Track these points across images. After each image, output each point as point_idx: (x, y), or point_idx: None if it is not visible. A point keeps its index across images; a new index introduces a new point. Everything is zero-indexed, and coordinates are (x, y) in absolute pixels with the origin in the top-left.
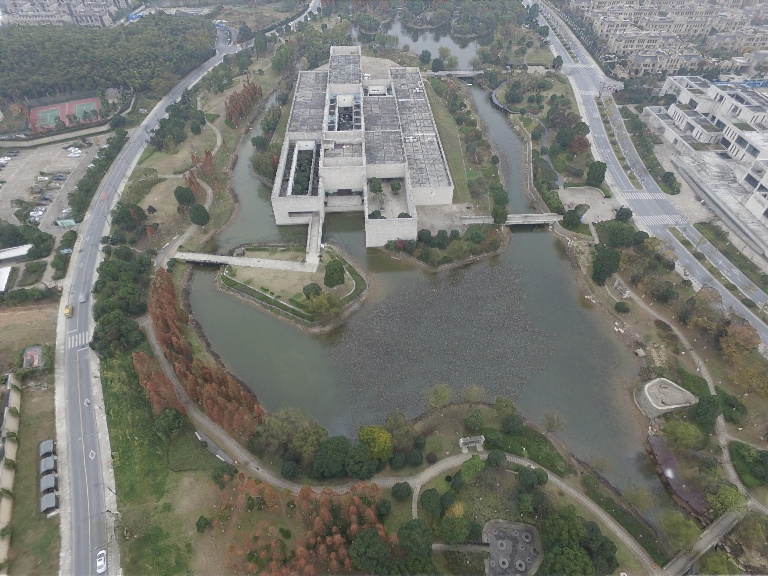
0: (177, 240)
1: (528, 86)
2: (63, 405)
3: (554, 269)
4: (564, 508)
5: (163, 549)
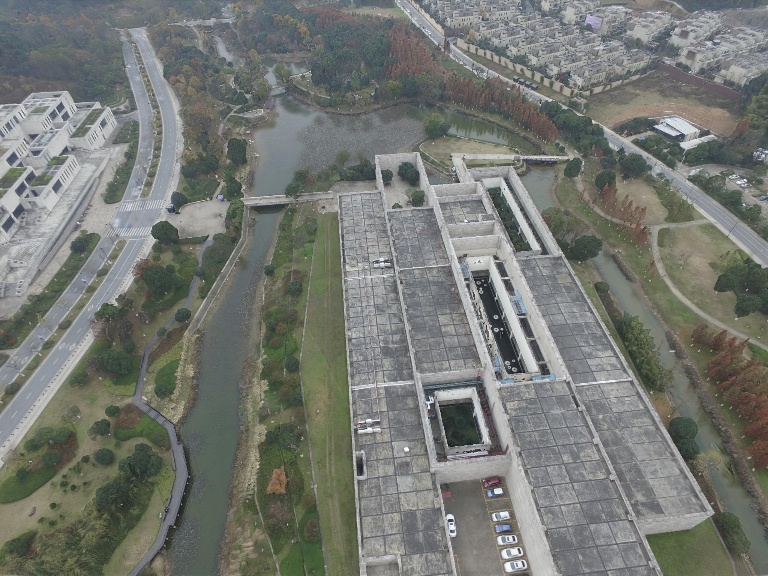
0: None
1: (65, 531)
2: (547, 99)
3: (269, 172)
4: None
5: (465, 75)
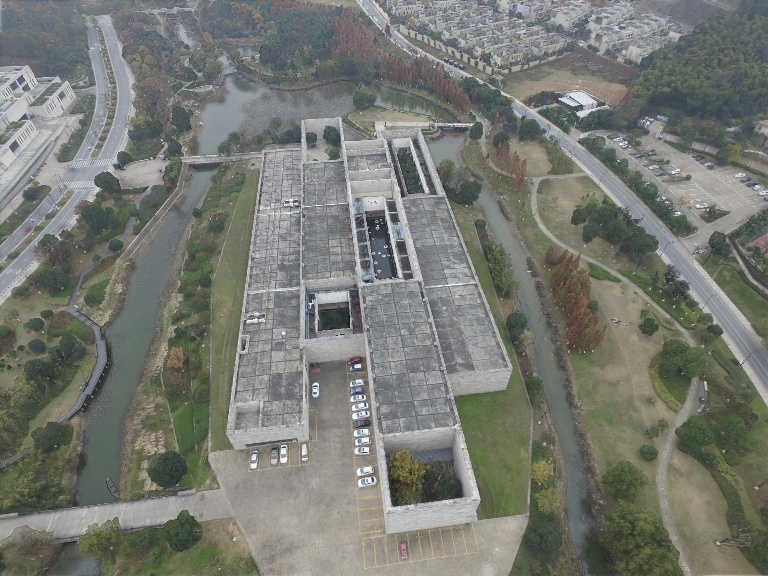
0: (486, 133)
1: None
2: None
3: (211, 137)
4: (272, 46)
5: None
